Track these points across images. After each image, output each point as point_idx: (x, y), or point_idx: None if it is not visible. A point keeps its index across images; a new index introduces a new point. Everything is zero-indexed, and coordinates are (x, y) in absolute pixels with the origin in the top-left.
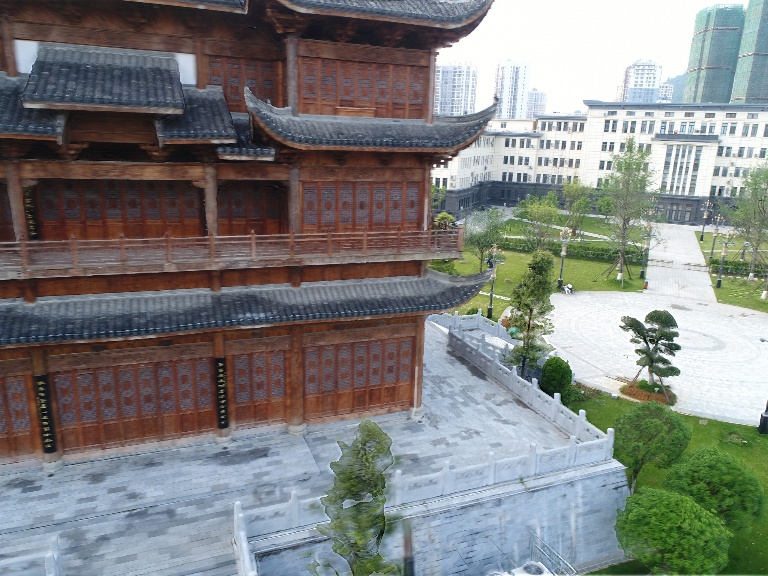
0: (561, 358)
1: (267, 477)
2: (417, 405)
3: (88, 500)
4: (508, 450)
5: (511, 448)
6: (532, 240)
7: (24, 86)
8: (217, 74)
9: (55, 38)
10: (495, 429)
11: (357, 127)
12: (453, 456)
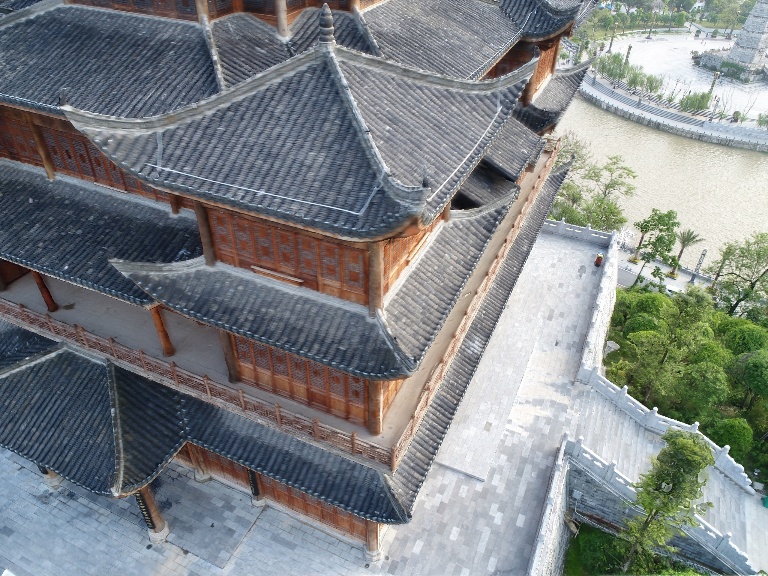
0: None
1: None
2: None
3: None
4: None
5: None
6: None
7: None
8: None
9: None
10: None
11: None
12: None
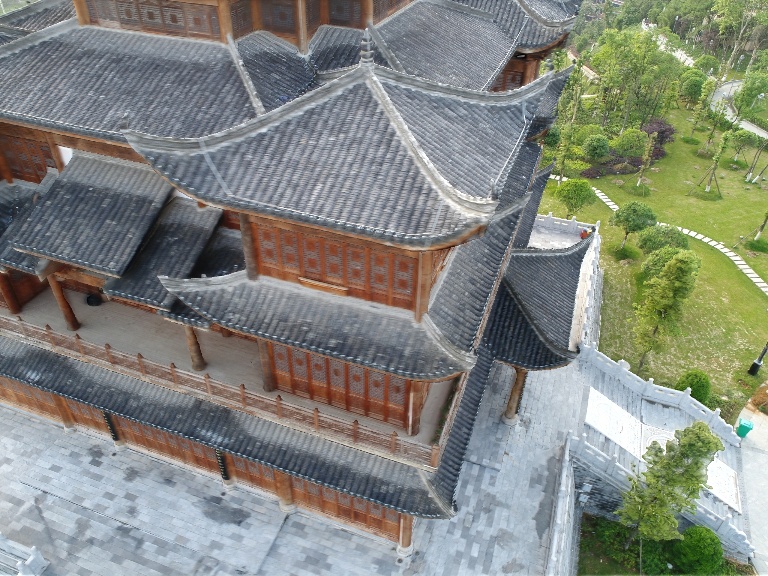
0: None
1: (216, 552)
2: (403, 545)
3: (109, 497)
4: None
5: None
6: None
7: None
8: None
9: (82, 147)
10: None
11: (315, 309)
12: None
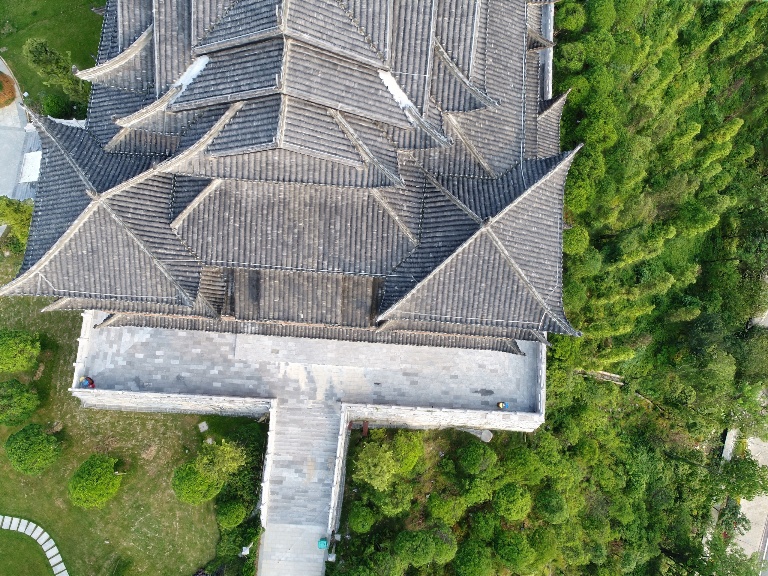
0: (0, 167)
1: None
2: None
3: None
4: None
5: None
6: None
7: None
8: None
9: None
10: None
11: None
12: None
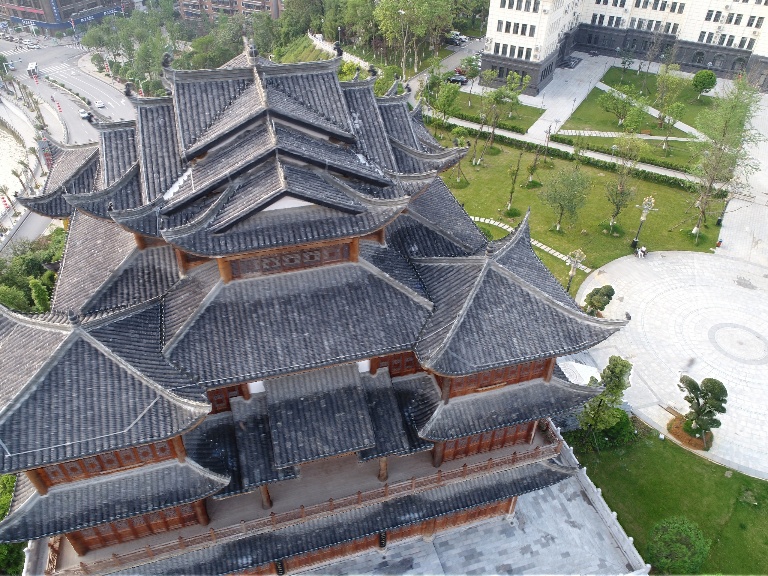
0: None
1: None
2: (511, 513)
3: None
4: (574, 562)
5: (576, 559)
6: (614, 194)
7: (258, 412)
8: (385, 360)
9: None
10: (566, 534)
11: (492, 403)
12: (536, 568)
